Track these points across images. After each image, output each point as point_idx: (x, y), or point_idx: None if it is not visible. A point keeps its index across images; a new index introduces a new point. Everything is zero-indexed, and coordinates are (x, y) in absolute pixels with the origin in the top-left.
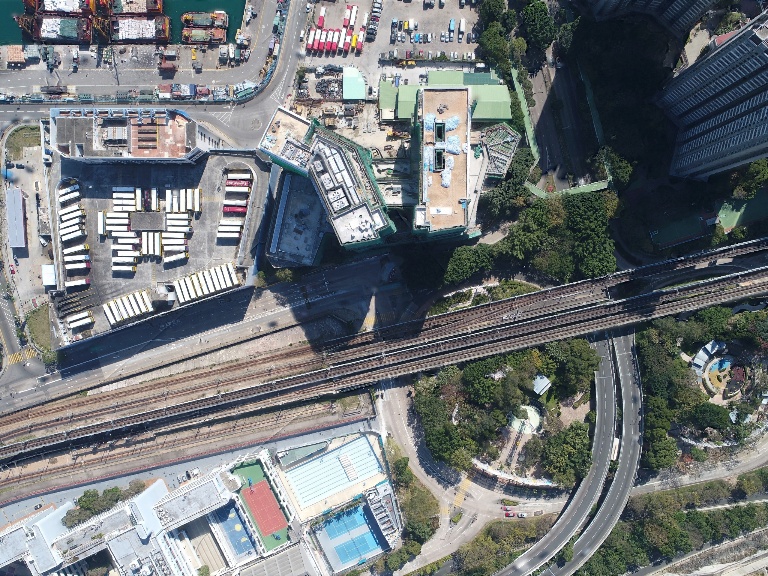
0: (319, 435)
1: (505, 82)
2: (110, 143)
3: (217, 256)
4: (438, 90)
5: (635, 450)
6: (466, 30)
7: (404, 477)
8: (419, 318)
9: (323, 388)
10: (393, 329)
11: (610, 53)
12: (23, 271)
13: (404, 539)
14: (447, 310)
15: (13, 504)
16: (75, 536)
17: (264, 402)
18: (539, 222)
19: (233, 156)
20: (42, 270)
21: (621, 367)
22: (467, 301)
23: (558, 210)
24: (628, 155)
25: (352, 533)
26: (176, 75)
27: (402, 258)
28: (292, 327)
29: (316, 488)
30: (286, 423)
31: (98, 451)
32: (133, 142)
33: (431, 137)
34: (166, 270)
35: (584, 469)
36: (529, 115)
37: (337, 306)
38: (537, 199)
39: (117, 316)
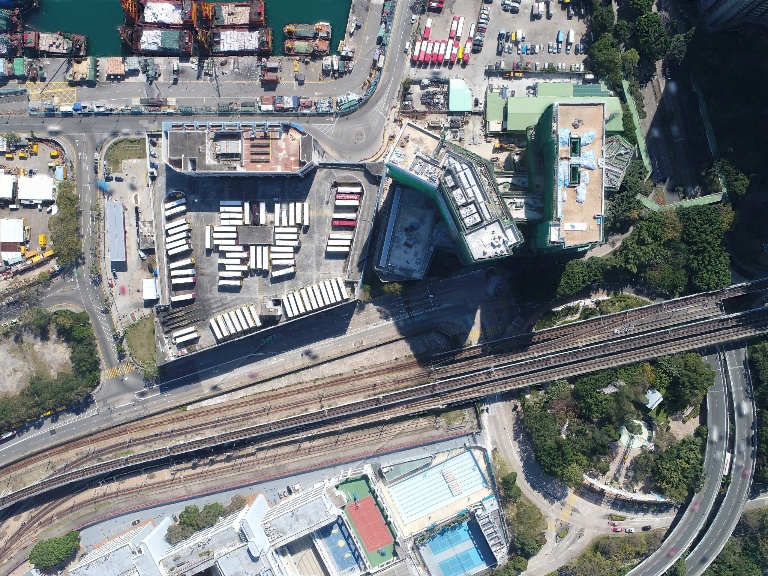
0: (423, 450)
1: (615, 94)
2: (222, 157)
3: (325, 270)
4: (573, 104)
5: (748, 465)
6: (574, 41)
7: (513, 492)
8: (525, 332)
9: (429, 403)
10: (501, 343)
11: (730, 65)
12: (122, 285)
13: (510, 555)
14: (554, 324)
15: (110, 520)
16: (182, 553)
17: (369, 417)
18: (654, 235)
19: (342, 169)
20: (143, 284)
21: (733, 381)
22: (575, 314)
23: (674, 223)
24: (745, 167)
25: (456, 549)
26: (278, 87)
27: (508, 271)
28: (396, 341)
29: (419, 503)
30: (389, 438)
31: (197, 466)
32: (245, 156)
33: (566, 152)
34: (273, 284)
35: (698, 484)
36: (640, 127)
37: (441, 320)
38: (650, 212)
39: (224, 331)
